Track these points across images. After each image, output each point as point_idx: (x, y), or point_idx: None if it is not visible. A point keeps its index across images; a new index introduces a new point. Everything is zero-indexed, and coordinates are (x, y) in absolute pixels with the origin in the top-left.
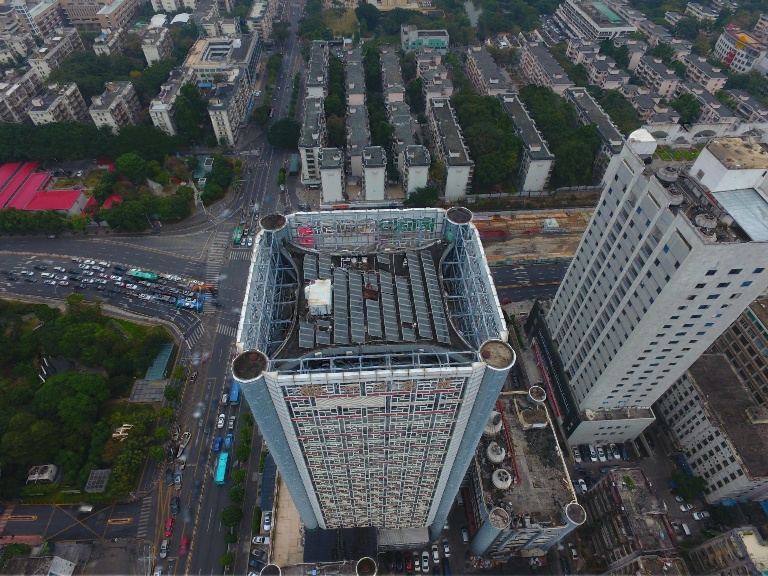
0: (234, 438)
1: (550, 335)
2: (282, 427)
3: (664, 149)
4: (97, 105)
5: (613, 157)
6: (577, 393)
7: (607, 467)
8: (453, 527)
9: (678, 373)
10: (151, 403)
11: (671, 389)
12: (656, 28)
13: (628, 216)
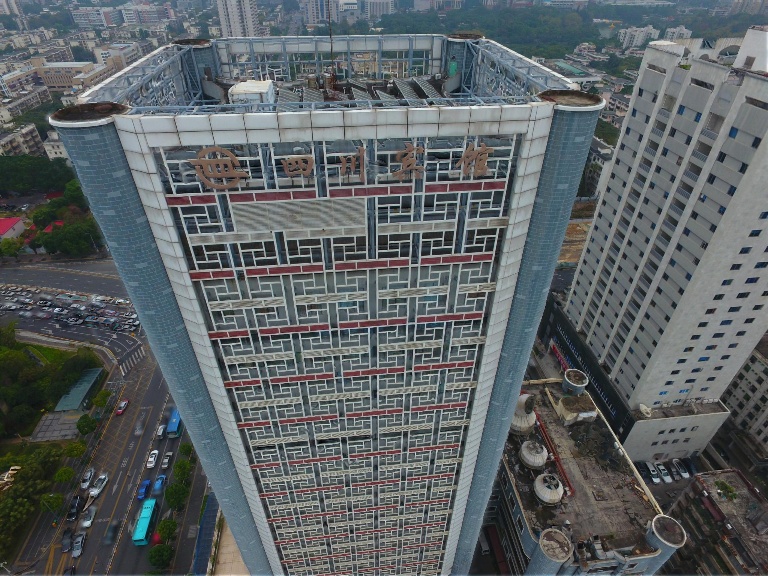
0: (168, 480)
1: (573, 327)
2: (180, 312)
3: (689, 66)
4: (53, 139)
5: (605, 164)
6: (622, 386)
7: (676, 490)
8: None
9: (755, 337)
10: (60, 441)
11: (736, 381)
12: (618, 80)
13: (666, 125)
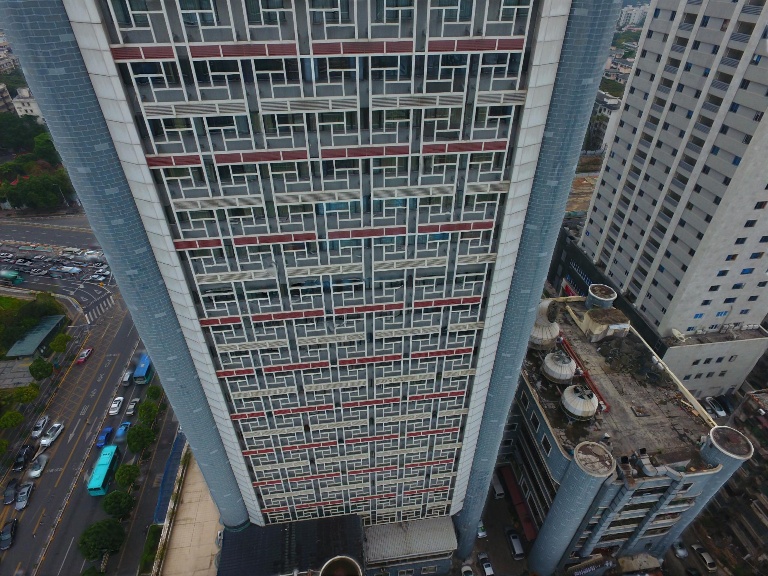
0: None
1: (589, 260)
2: (64, 8)
3: None
4: (23, 97)
5: (612, 114)
6: (650, 313)
7: None
8: (493, 534)
9: None
10: (11, 389)
11: None
12: (618, 50)
13: None
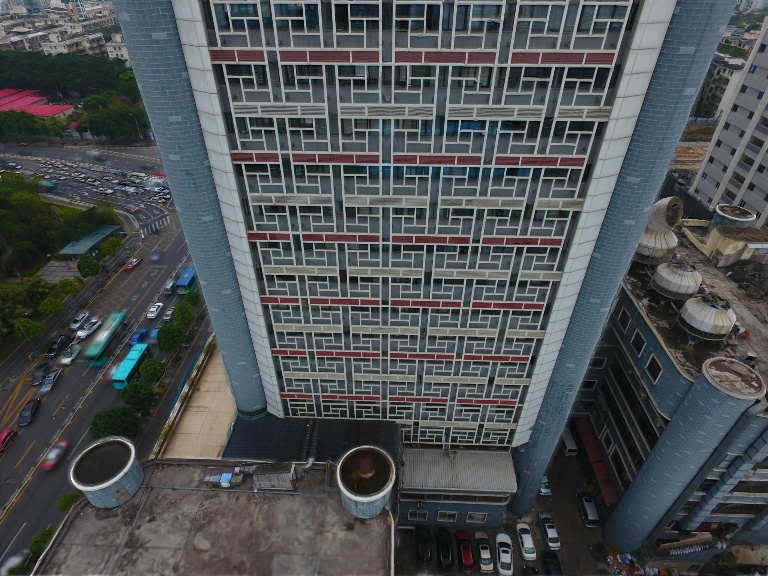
0: None
1: (704, 207)
2: None
3: None
4: (116, 42)
5: (734, 75)
6: None
7: None
8: (560, 494)
9: None
10: None
11: None
12: (737, 29)
13: None
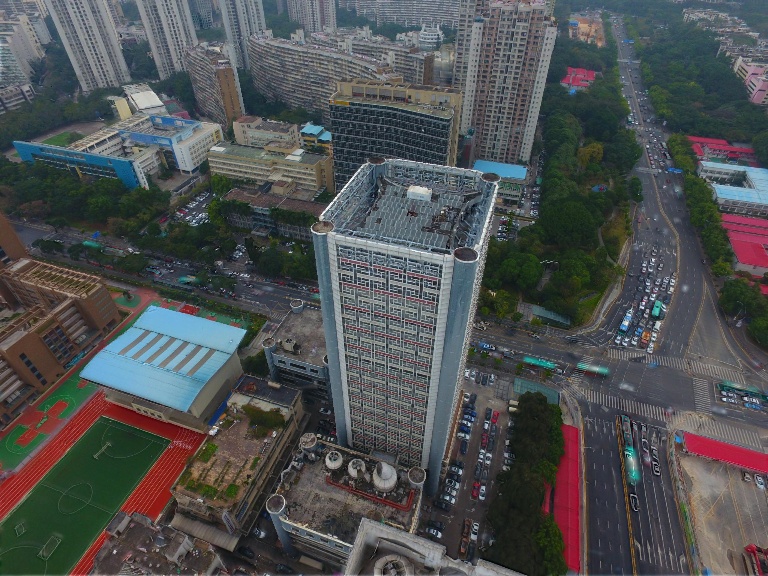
0: None
1: None
2: None
3: None
4: None
5: None
6: None
7: None
8: None
9: None
10: None
11: None
12: None
13: None
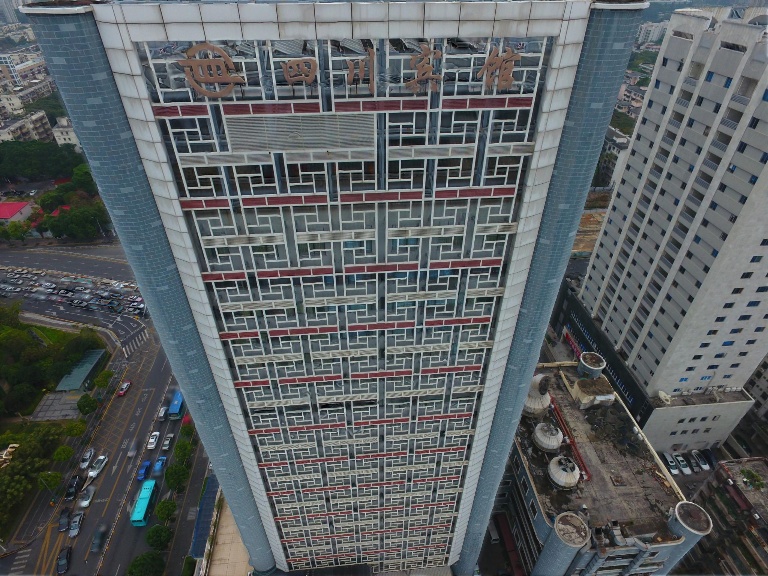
0: (168, 462)
1: (588, 313)
2: (171, 250)
3: None
4: (62, 125)
5: (620, 153)
6: (640, 373)
7: (695, 482)
8: None
9: None
10: (60, 421)
11: (760, 370)
12: (633, 73)
13: (692, 94)
